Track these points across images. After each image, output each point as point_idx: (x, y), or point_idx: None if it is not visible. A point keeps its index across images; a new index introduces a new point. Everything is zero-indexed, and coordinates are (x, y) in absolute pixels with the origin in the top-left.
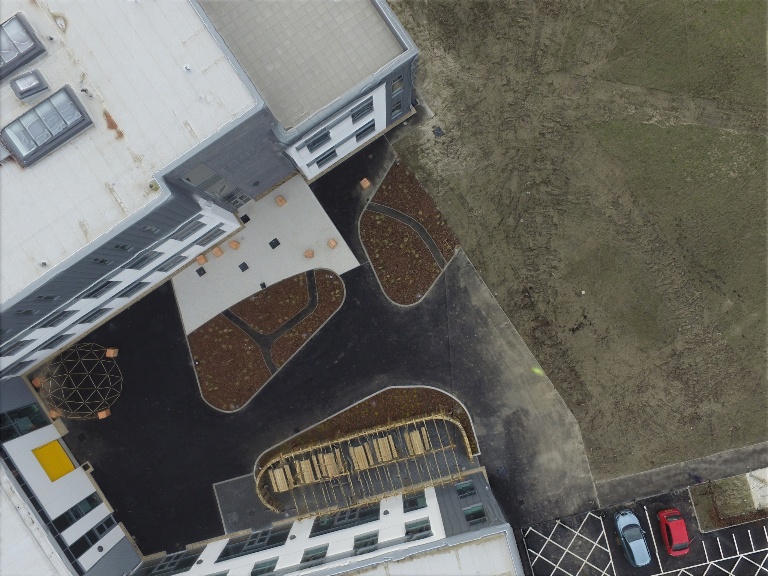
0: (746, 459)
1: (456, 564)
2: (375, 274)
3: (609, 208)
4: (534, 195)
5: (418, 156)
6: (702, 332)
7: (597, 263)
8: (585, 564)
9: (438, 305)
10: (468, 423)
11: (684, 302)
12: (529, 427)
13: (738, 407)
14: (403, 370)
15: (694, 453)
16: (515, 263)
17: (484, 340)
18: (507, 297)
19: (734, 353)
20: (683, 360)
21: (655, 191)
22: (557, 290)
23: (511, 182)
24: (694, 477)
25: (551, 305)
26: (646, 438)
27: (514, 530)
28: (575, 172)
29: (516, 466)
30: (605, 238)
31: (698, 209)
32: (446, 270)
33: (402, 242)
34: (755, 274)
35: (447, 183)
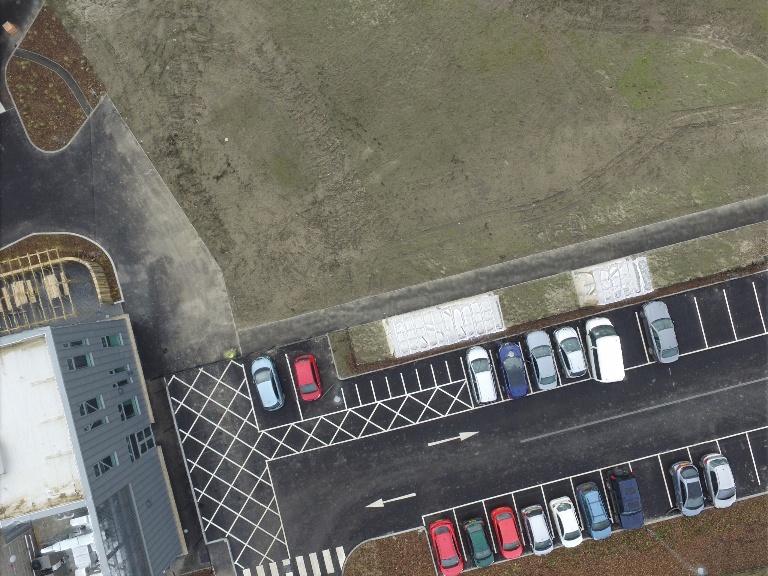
0: (383, 305)
1: (1, 369)
2: (20, 120)
3: (253, 55)
4: (180, 42)
5: (66, 2)
6: (342, 179)
7: (241, 110)
8: (227, 412)
9: (83, 152)
10: (111, 270)
11: (325, 150)
12: (172, 275)
13: (376, 254)
14: (47, 217)
15: (333, 300)
16: (160, 110)
17: (129, 187)
18: (153, 144)
19: (373, 200)
20: (324, 208)
21: (297, 38)
22: (201, 137)
23: (157, 29)
24: (333, 324)
25: (195, 152)
26: (287, 285)
27: (157, 378)
28: (220, 19)
29: (159, 314)
30: (249, 85)
31: (340, 57)
32: (92, 117)
33: (47, 88)
34: (395, 122)
35: (94, 29)
